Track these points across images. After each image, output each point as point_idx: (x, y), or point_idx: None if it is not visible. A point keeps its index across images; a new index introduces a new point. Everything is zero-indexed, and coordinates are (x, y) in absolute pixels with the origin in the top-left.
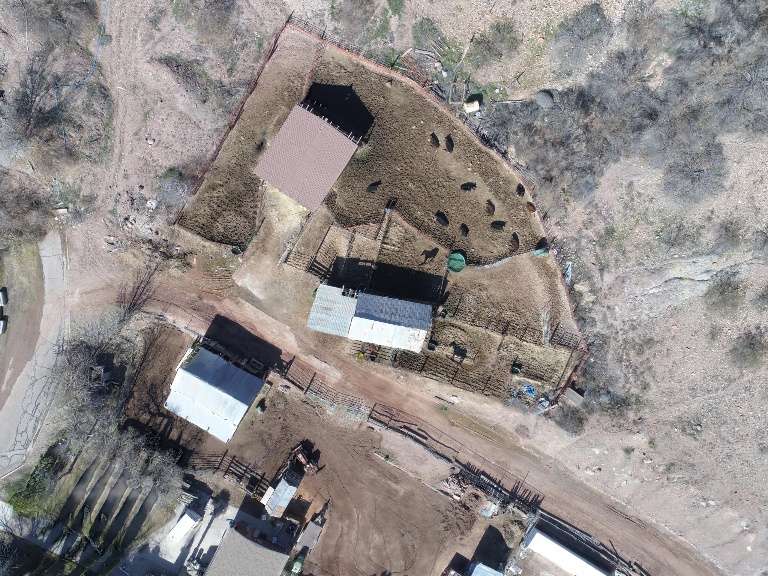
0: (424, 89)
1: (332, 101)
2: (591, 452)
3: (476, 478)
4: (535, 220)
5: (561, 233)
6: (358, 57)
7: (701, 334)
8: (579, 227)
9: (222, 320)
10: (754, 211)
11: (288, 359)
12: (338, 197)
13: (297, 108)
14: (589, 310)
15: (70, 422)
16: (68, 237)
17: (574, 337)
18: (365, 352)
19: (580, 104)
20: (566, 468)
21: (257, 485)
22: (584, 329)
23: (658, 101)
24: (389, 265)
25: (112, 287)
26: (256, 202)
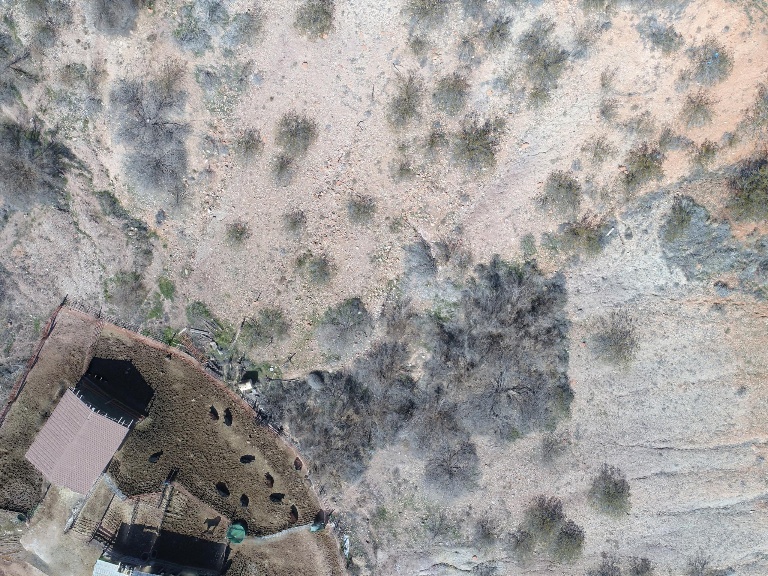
0: (202, 365)
1: (112, 375)
2: None
3: None
4: (313, 493)
5: (337, 508)
6: (136, 333)
7: None
8: (353, 504)
9: None
10: (506, 514)
11: None
12: (121, 466)
13: (69, 393)
14: None
15: None
16: None
17: None
18: None
19: (348, 388)
20: None
21: None
22: None
23: (420, 392)
24: (173, 533)
25: None
26: None
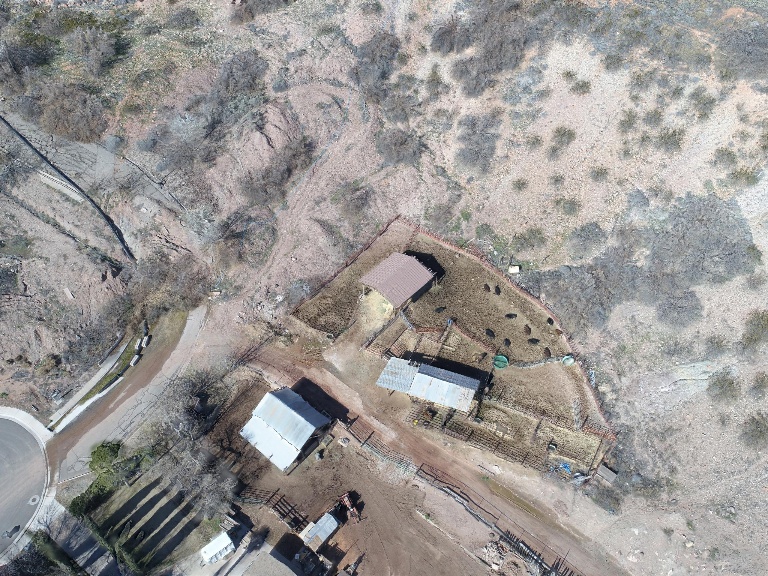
0: (481, 260)
1: None
2: (631, 533)
3: (515, 547)
4: (563, 341)
5: (584, 349)
6: (439, 241)
7: (712, 422)
8: (597, 345)
9: (306, 381)
10: (729, 329)
11: (353, 417)
12: (413, 313)
13: (396, 253)
14: (613, 406)
15: (151, 443)
16: (212, 310)
17: (602, 428)
18: (419, 420)
19: (590, 273)
20: (608, 553)
21: (298, 526)
22: (610, 421)
23: None
24: (447, 359)
25: (230, 346)
26: (353, 310)
